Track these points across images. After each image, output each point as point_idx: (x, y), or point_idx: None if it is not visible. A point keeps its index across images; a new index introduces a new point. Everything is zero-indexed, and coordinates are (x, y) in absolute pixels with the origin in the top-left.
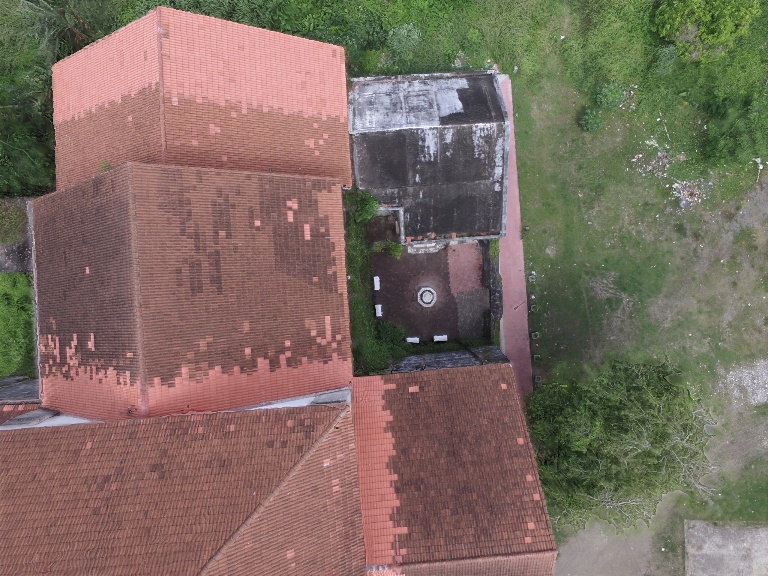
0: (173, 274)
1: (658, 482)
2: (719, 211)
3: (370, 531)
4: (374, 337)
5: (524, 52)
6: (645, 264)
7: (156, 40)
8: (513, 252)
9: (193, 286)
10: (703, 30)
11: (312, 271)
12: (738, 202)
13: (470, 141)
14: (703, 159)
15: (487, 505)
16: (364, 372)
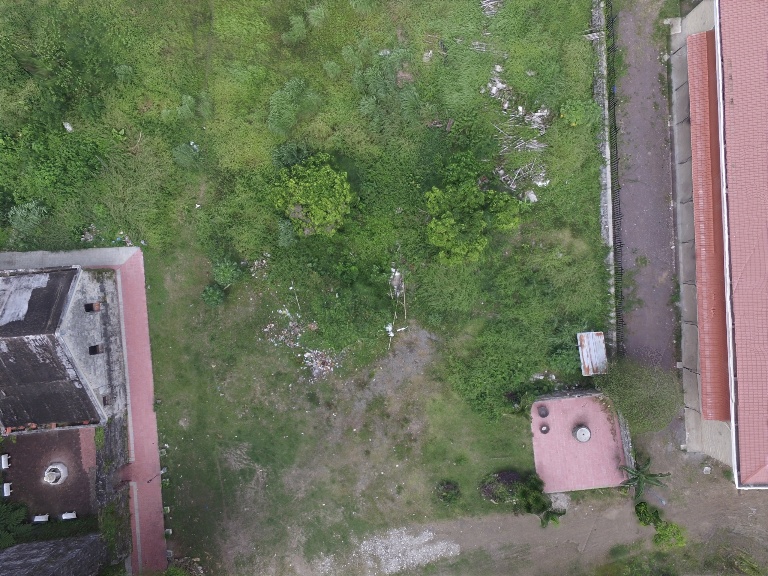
0: None
1: None
2: (351, 379)
3: None
4: None
5: (152, 225)
6: (278, 434)
7: None
8: (146, 425)
9: None
10: (306, 211)
11: None
12: (371, 370)
13: (28, 350)
14: None
15: None
16: None
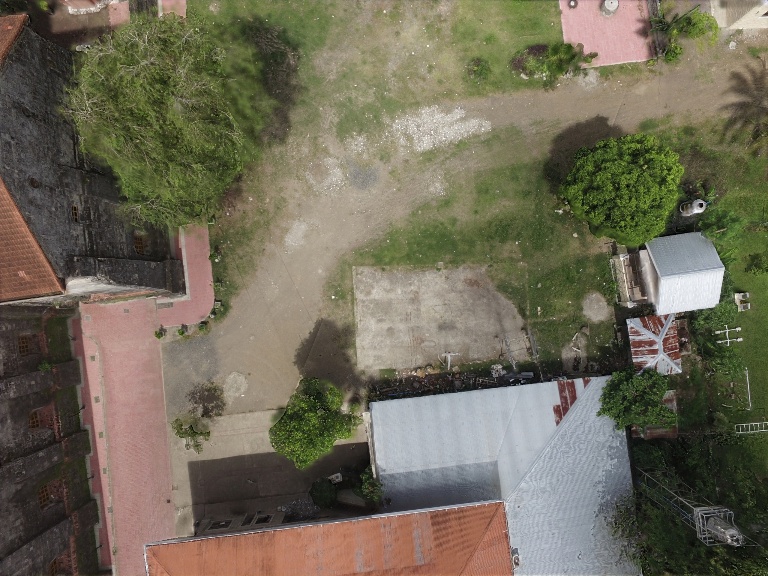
0: None
1: (129, 90)
2: None
3: None
4: None
5: None
6: (308, 17)
7: None
8: (177, 10)
9: None
10: None
11: None
12: None
13: None
14: None
15: None
16: None
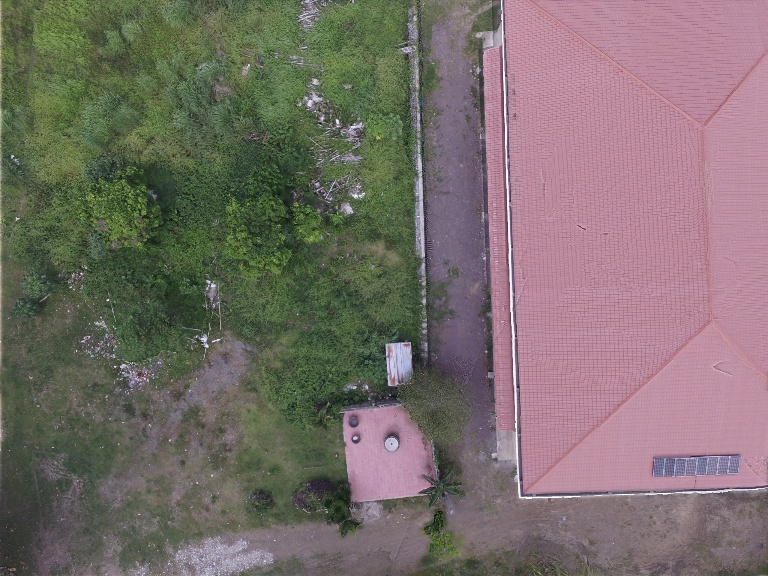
0: None
1: None
2: (167, 390)
3: None
4: None
5: None
6: (94, 445)
7: None
8: None
9: None
10: None
11: None
12: (186, 381)
13: None
14: None
15: None
16: None
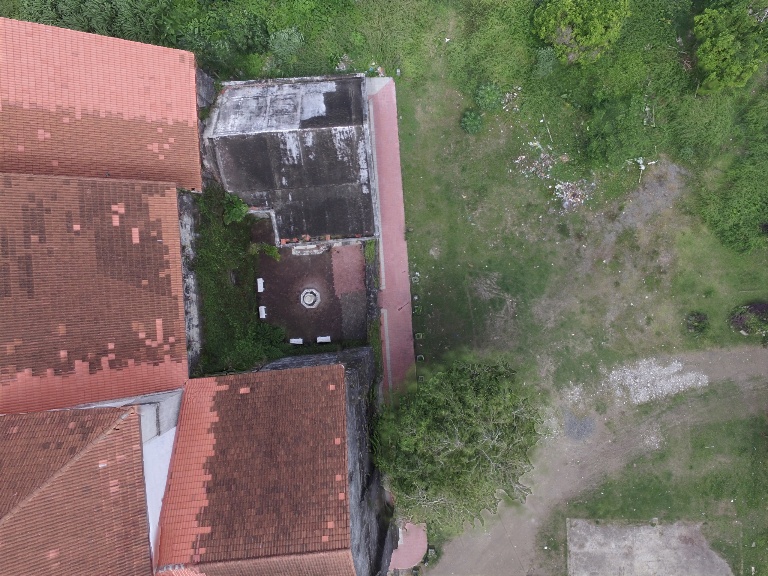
0: None
1: (472, 481)
2: (602, 212)
3: (173, 531)
4: (252, 338)
5: (407, 55)
6: (528, 265)
7: None
8: (397, 253)
9: None
10: (577, 32)
11: (141, 274)
12: (621, 203)
13: (331, 144)
14: (585, 160)
15: (292, 504)
16: (201, 374)
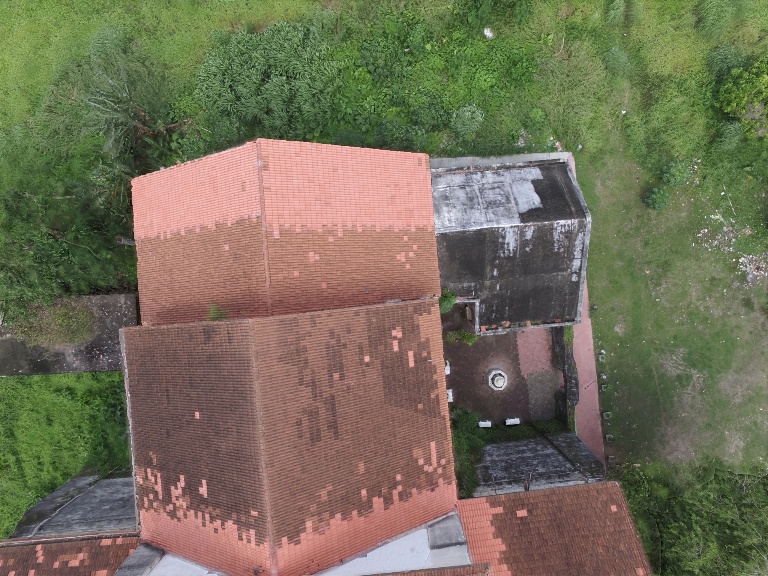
0: (294, 427)
1: None
2: None
3: None
4: None
5: (587, 130)
6: (714, 339)
7: (256, 173)
8: (582, 331)
9: (312, 436)
10: None
11: (417, 398)
12: None
13: (550, 237)
14: None
15: None
16: (468, 493)
